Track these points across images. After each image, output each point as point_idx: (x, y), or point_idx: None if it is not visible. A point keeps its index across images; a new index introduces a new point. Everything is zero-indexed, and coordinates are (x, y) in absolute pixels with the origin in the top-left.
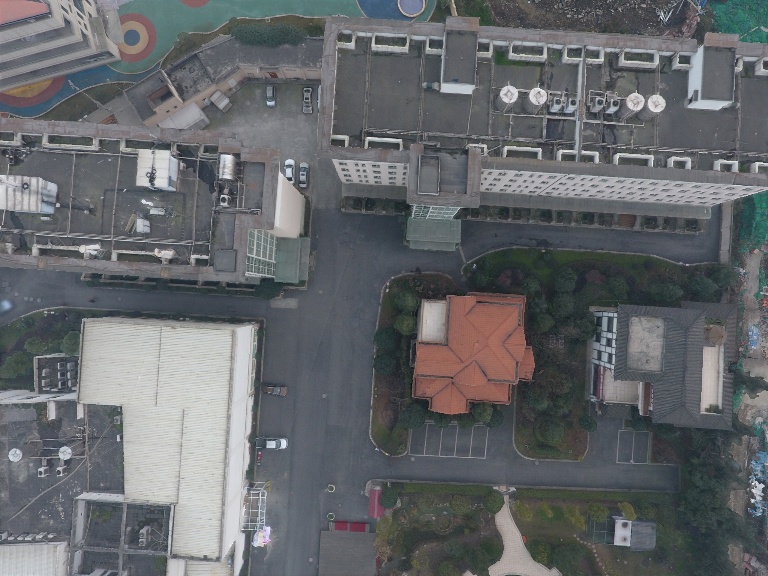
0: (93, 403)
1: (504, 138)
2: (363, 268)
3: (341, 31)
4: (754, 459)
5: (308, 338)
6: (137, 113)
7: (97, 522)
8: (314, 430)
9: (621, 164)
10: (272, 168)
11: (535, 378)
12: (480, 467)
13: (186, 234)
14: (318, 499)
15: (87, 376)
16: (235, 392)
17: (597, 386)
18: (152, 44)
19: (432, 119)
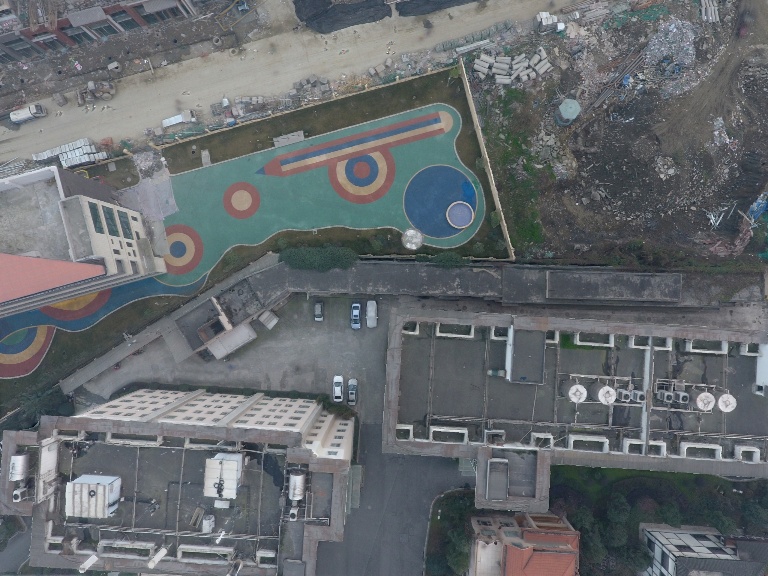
0: None
1: (570, 425)
2: (412, 483)
3: None
4: None
5: (357, 554)
6: (187, 343)
7: None
8: None
9: (688, 452)
10: (341, 479)
11: None
12: None
13: (251, 527)
14: None
15: None
16: None
17: None
18: (198, 256)
19: (497, 404)
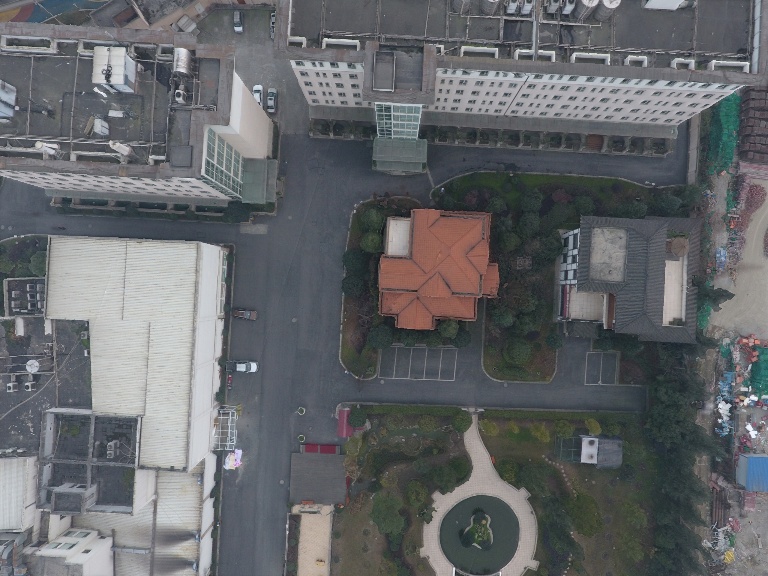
0: (60, 318)
1: (461, 39)
2: (332, 193)
3: None
4: (721, 380)
5: (278, 263)
6: None
7: (66, 437)
8: (284, 354)
9: None
10: (227, 64)
11: (503, 300)
12: (449, 389)
13: (145, 136)
14: (289, 422)
15: (54, 291)
16: (201, 306)
17: (563, 305)
18: None
19: (390, 22)
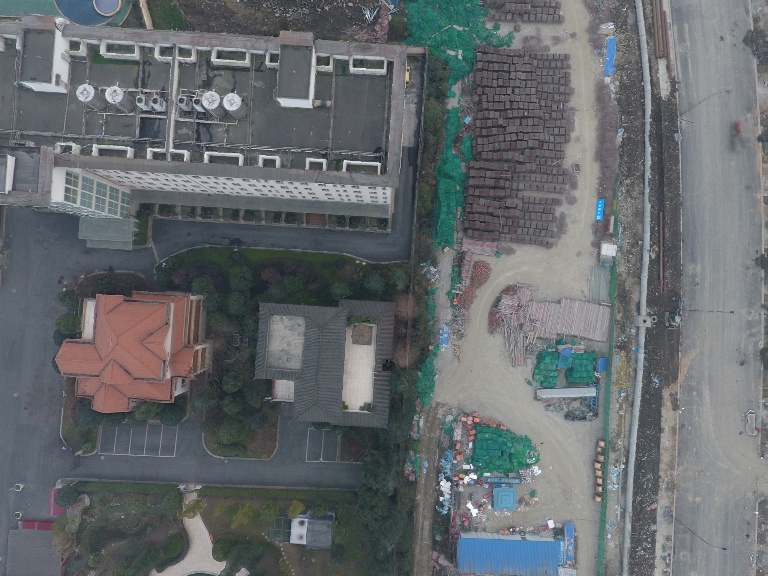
0: None
1: (97, 137)
2: (56, 267)
3: None
4: (443, 457)
5: (1, 337)
6: None
7: None
8: (5, 429)
9: (214, 162)
10: None
11: None
12: (169, 466)
13: None
14: (8, 498)
15: None
16: None
17: (272, 384)
18: None
19: (28, 118)
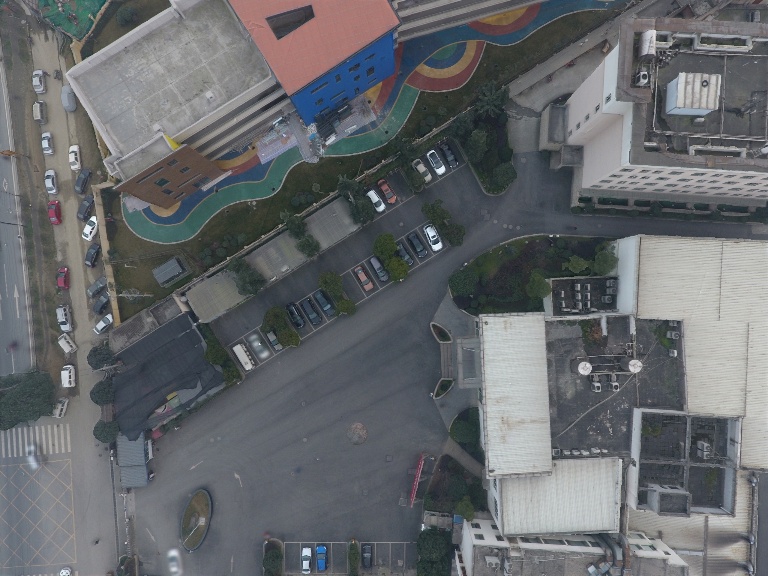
0: (652, 318)
1: None
2: None
3: None
4: None
5: None
6: None
7: (648, 438)
8: None
9: None
10: None
11: None
12: None
13: None
14: None
15: (645, 291)
16: None
17: None
18: None
19: None
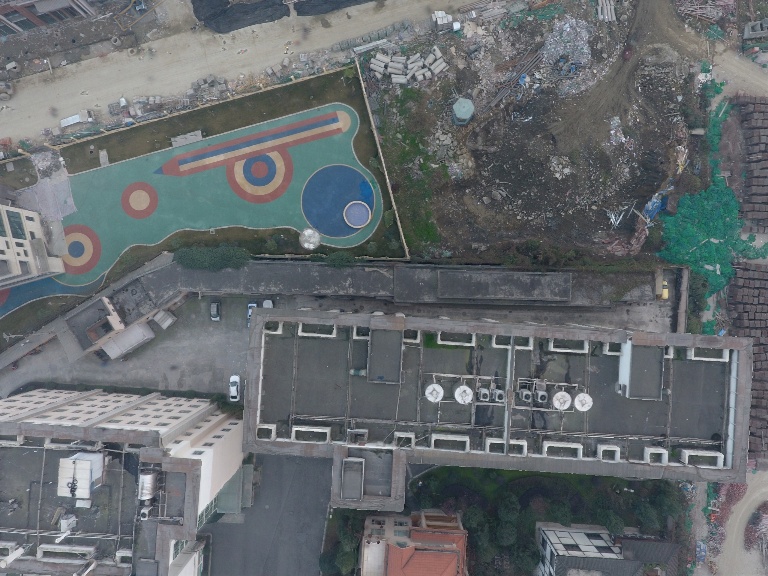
0: None
1: (432, 425)
2: (309, 483)
3: (267, 321)
4: None
5: (255, 553)
6: (78, 342)
7: None
8: None
9: (551, 451)
10: (193, 478)
11: None
12: None
13: (112, 526)
14: None
15: None
16: None
17: None
18: (96, 256)
19: (360, 403)
